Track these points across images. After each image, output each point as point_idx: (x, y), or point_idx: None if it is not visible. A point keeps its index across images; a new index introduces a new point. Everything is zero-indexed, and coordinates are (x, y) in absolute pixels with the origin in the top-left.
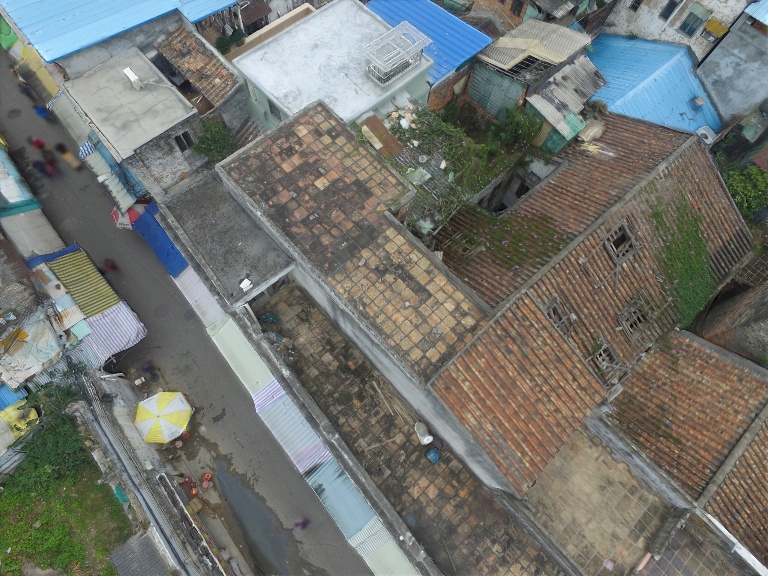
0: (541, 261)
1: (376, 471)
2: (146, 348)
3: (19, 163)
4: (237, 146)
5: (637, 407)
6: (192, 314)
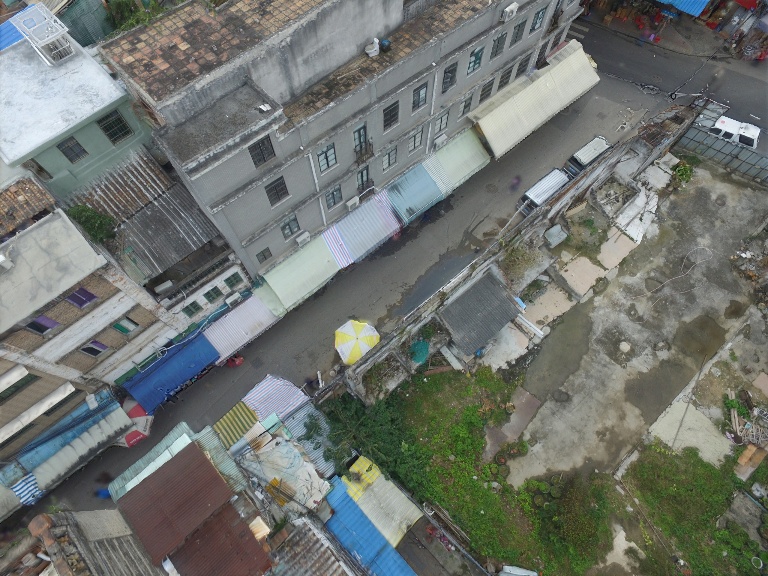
0: None
1: None
2: None
3: None
4: None
5: None
6: (256, 361)
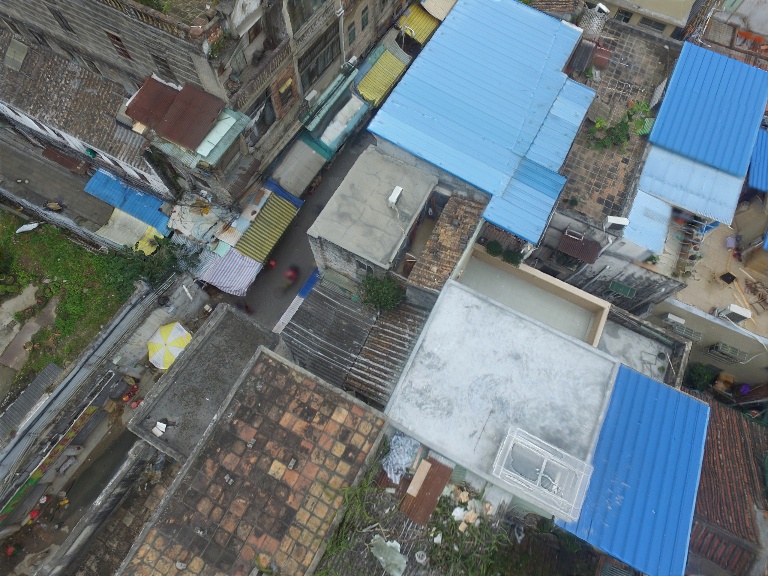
0: None
1: None
2: (243, 297)
3: None
4: (398, 310)
5: None
6: None
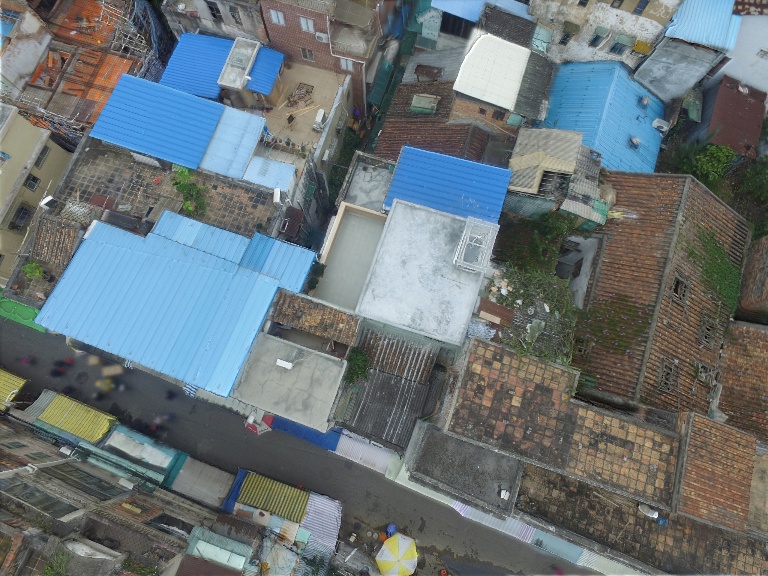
0: (642, 339)
1: (631, 549)
2: None
3: (121, 419)
4: None
5: (738, 395)
6: (350, 462)
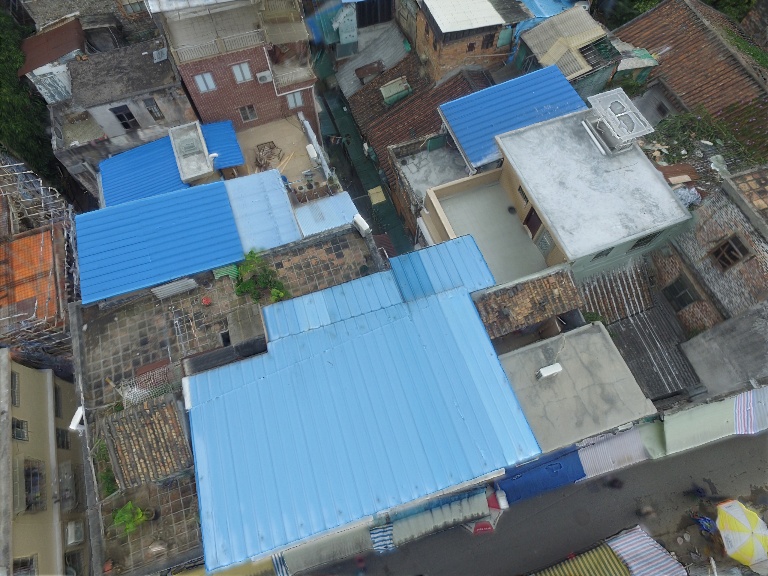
0: None
1: None
2: None
3: None
4: None
5: None
6: (592, 483)
